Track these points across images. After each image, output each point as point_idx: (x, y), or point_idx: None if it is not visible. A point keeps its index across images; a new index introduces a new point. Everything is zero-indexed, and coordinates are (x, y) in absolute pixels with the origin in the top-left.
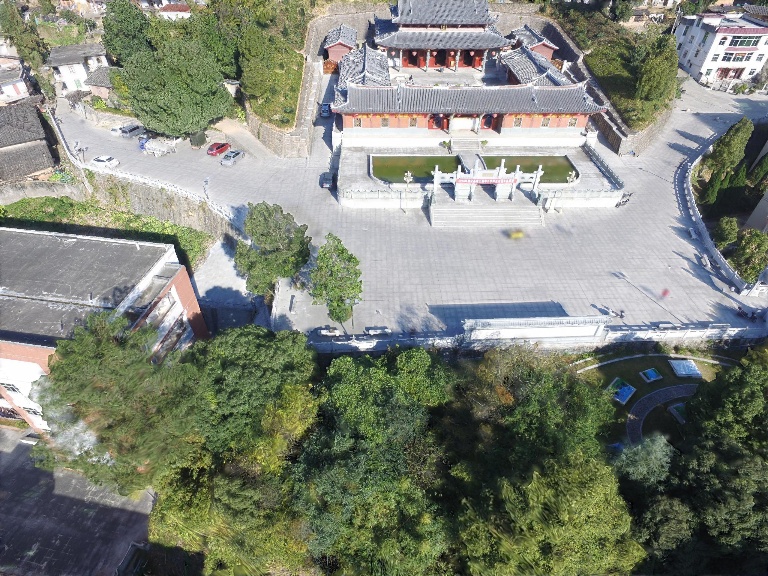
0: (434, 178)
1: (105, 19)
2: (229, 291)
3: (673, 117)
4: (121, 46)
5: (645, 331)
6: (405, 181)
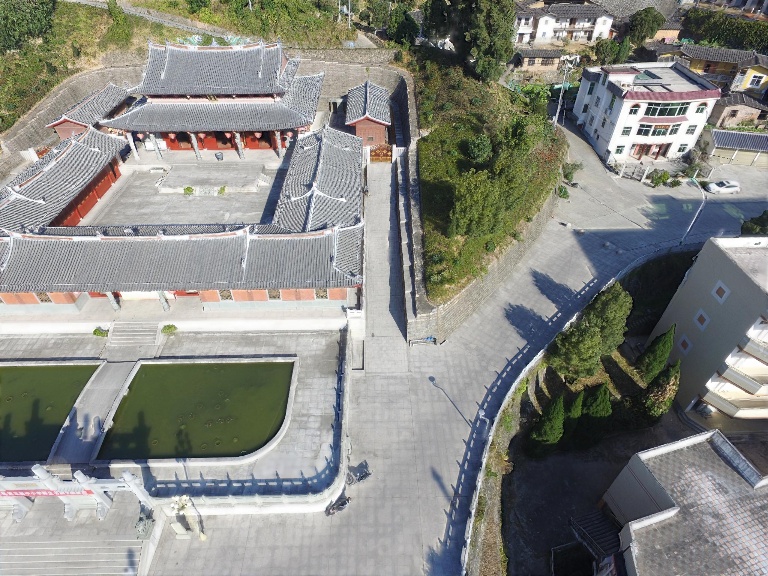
0: None
1: None
2: None
3: (541, 240)
4: None
5: None
6: None
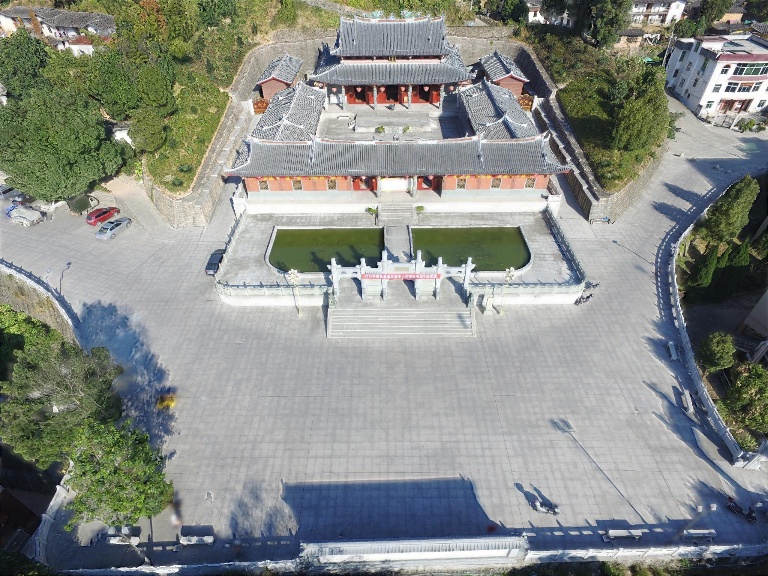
0: (332, 273)
1: None
2: None
3: (663, 165)
4: (20, 86)
5: (583, 551)
6: (307, 268)
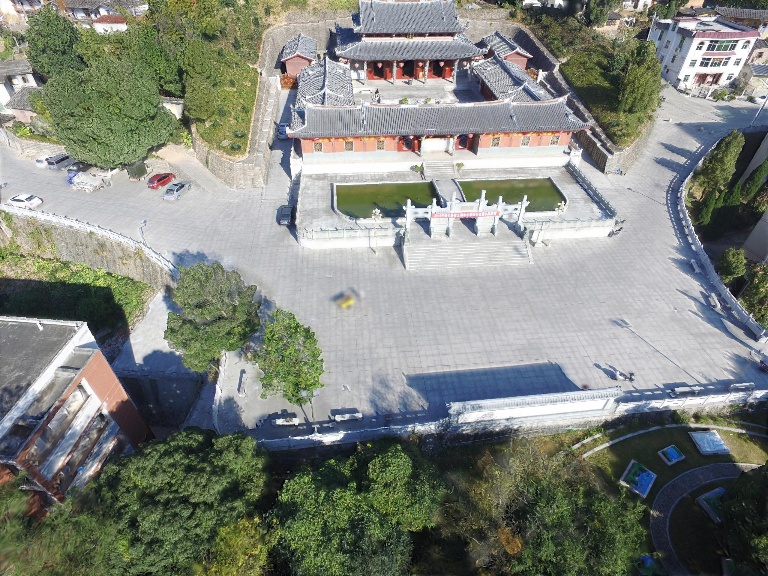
0: (406, 214)
1: (28, 33)
2: (171, 356)
3: (656, 128)
4: (49, 63)
5: (661, 400)
6: None
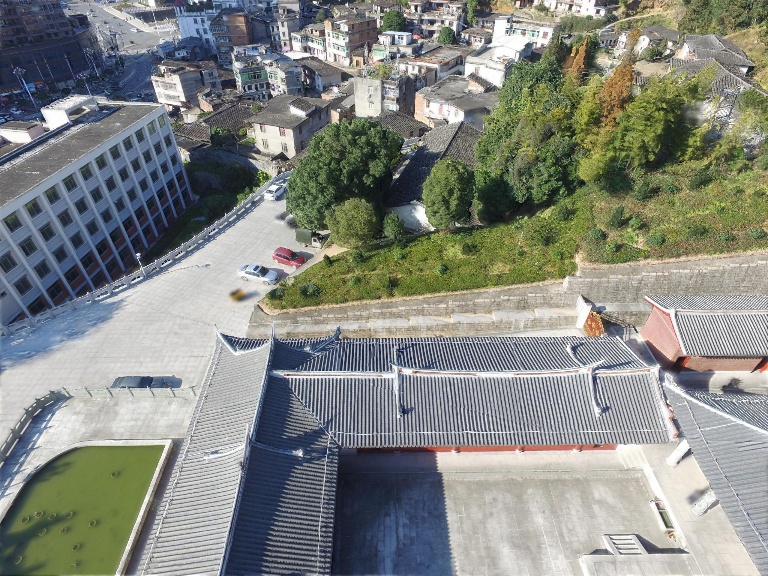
0: None
1: None
2: None
3: None
4: None
5: None
6: (30, 509)
